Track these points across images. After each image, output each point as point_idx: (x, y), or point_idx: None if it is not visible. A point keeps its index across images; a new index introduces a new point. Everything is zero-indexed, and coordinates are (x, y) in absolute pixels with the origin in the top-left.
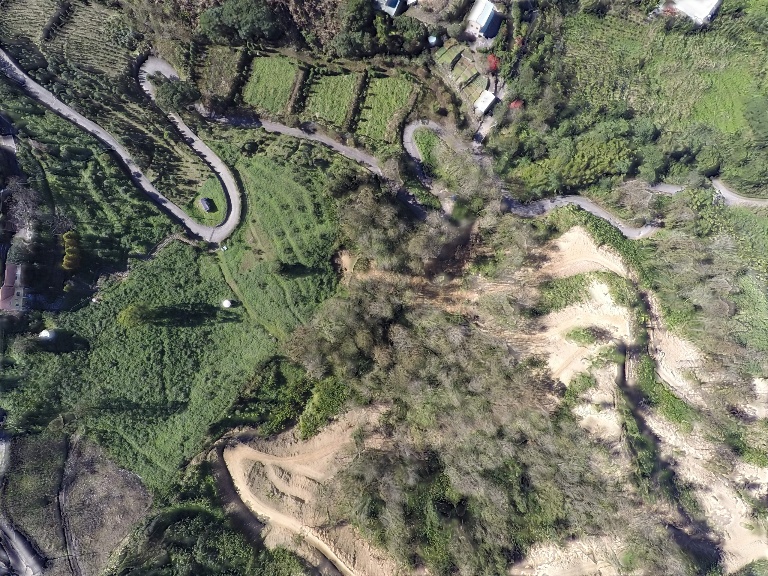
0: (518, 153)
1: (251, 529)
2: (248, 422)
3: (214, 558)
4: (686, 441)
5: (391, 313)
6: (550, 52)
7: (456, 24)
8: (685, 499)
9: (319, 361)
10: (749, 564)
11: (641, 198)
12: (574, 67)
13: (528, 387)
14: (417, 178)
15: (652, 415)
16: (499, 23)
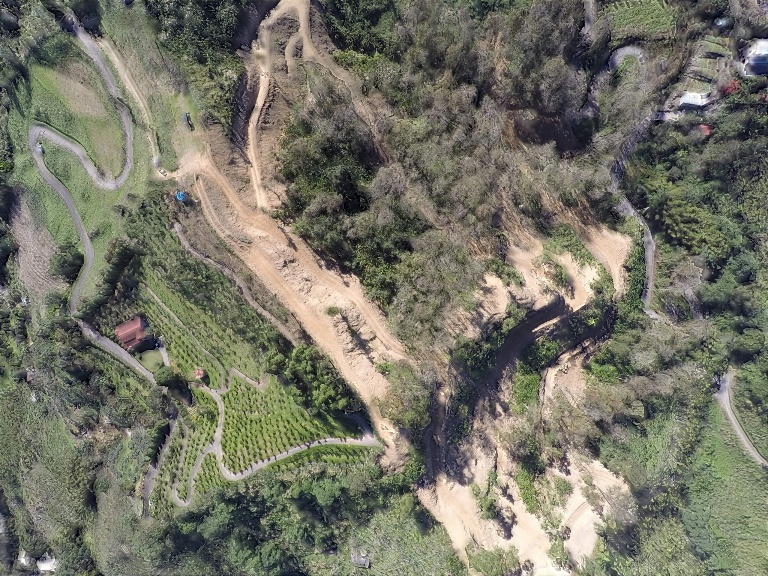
0: (661, 156)
1: (244, 35)
2: (329, 1)
3: (210, 3)
4: (510, 414)
5: (487, 71)
6: (766, 129)
7: (744, 30)
8: (461, 432)
9: (421, 16)
10: (437, 520)
11: (692, 274)
12: (760, 170)
13: (483, 233)
14: (593, 76)
15: (512, 376)
16: (764, 73)
